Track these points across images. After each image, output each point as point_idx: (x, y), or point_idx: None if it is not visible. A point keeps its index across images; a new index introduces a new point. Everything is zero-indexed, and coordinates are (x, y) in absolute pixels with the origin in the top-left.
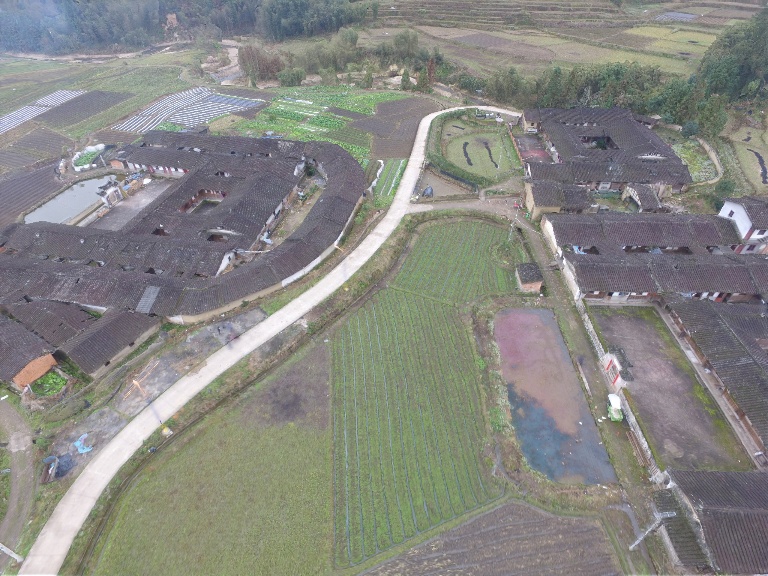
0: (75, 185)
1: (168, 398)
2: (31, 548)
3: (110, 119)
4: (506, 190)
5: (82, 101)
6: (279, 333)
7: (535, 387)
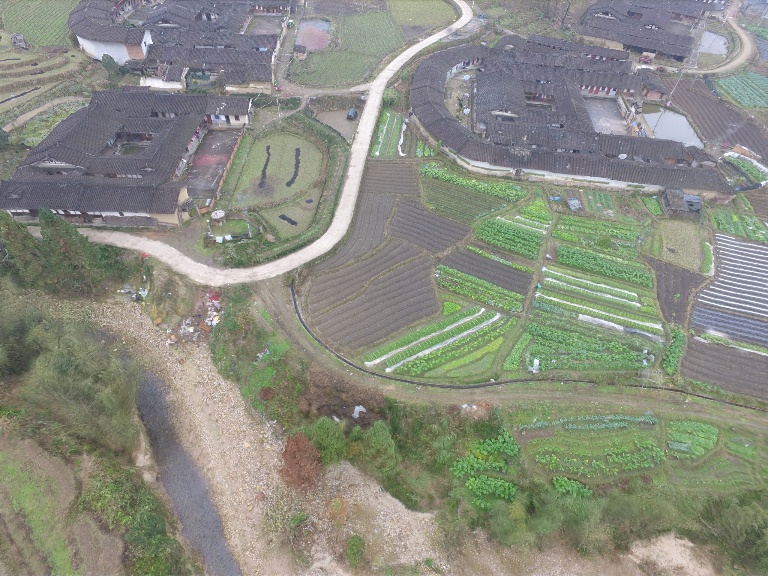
0: None
1: (461, 24)
2: None
3: None
4: None
5: None
6: None
7: (317, 32)
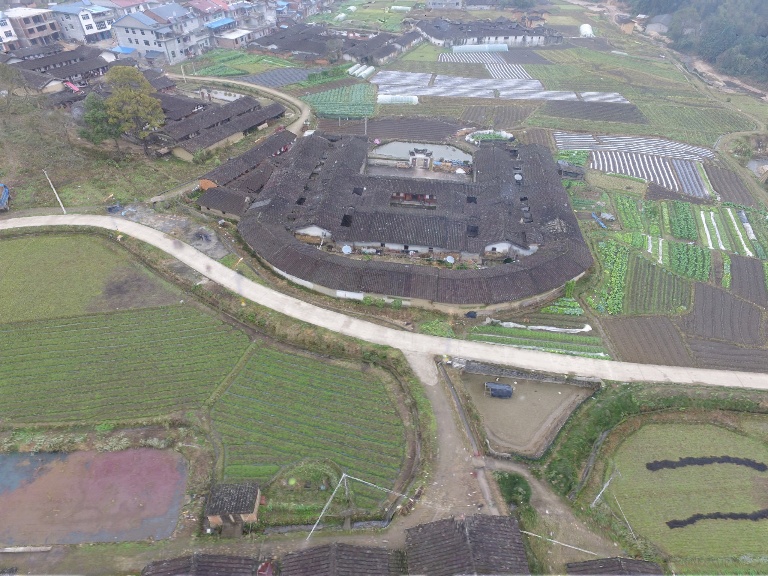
0: (448, 146)
1: (147, 231)
2: (69, 214)
3: (576, 127)
4: (546, 521)
5: (604, 107)
6: (194, 269)
7: (47, 485)
